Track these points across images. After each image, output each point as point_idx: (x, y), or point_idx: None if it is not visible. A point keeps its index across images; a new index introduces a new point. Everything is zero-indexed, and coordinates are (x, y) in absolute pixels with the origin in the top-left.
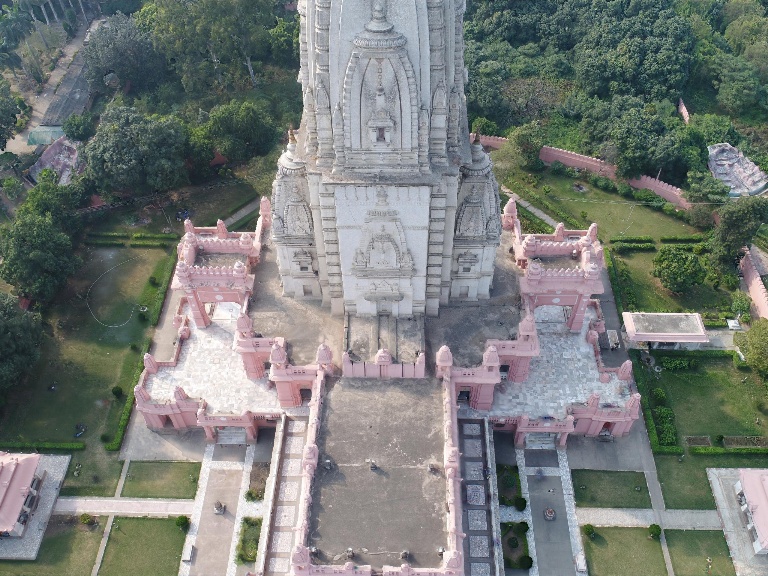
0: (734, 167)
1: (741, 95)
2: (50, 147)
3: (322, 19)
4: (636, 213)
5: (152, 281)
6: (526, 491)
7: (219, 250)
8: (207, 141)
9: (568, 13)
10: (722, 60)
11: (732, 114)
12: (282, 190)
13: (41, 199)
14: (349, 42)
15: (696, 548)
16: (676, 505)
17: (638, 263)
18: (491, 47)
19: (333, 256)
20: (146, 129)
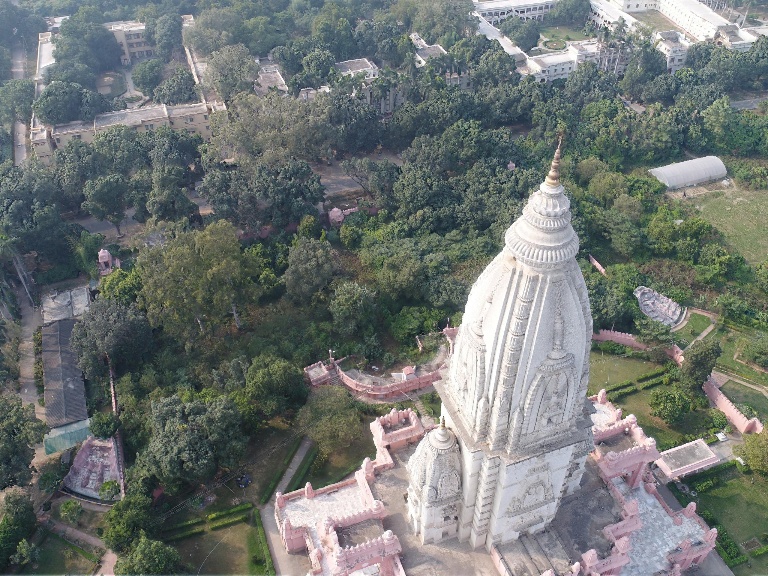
0: (656, 304)
1: (631, 242)
2: (80, 452)
3: (514, 358)
4: (607, 362)
5: (255, 560)
6: None
7: (353, 522)
8: (253, 406)
9: (475, 200)
10: (605, 216)
11: (628, 257)
12: (437, 467)
13: (129, 519)
14: (535, 368)
15: None
16: None
17: (632, 406)
18: (423, 240)
19: (487, 506)
20: (212, 419)
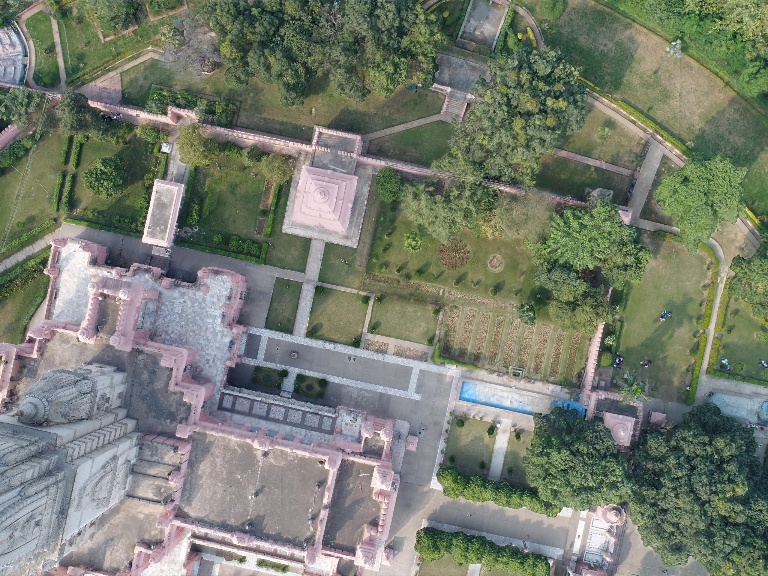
0: None
1: None
2: None
3: None
4: None
5: None
6: (275, 366)
7: None
8: None
9: None
10: None
11: None
12: None
13: None
14: None
15: (334, 266)
16: (304, 265)
17: (87, 197)
18: None
19: None
20: None
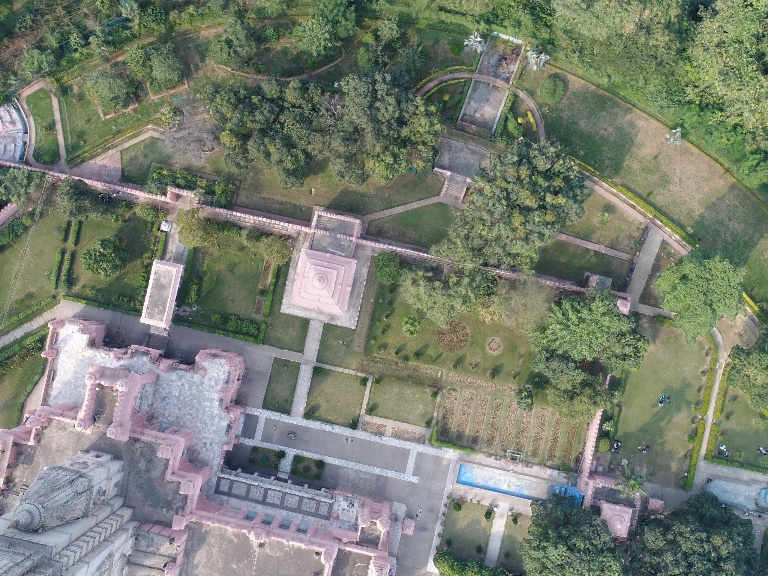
0: None
1: None
2: None
3: None
4: None
5: None
6: (272, 446)
7: None
8: None
9: None
10: None
11: None
12: None
13: None
14: None
15: (332, 346)
16: (302, 346)
17: (85, 275)
18: None
19: None
20: None
